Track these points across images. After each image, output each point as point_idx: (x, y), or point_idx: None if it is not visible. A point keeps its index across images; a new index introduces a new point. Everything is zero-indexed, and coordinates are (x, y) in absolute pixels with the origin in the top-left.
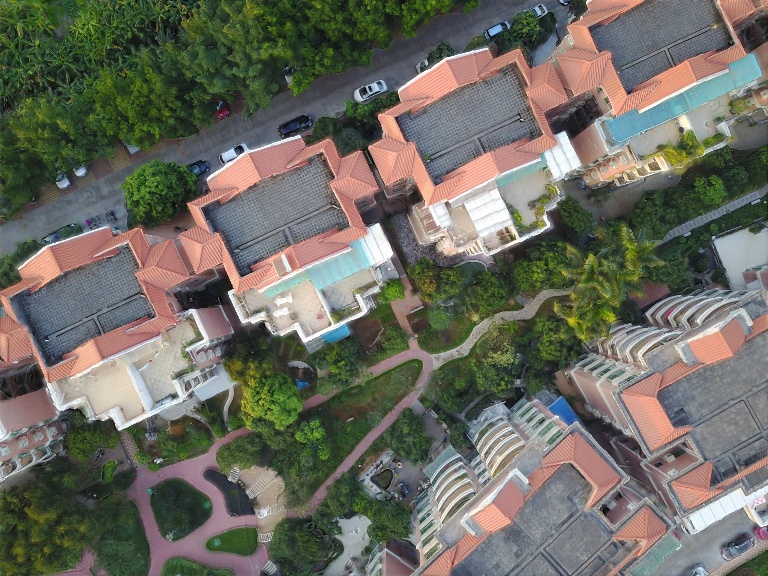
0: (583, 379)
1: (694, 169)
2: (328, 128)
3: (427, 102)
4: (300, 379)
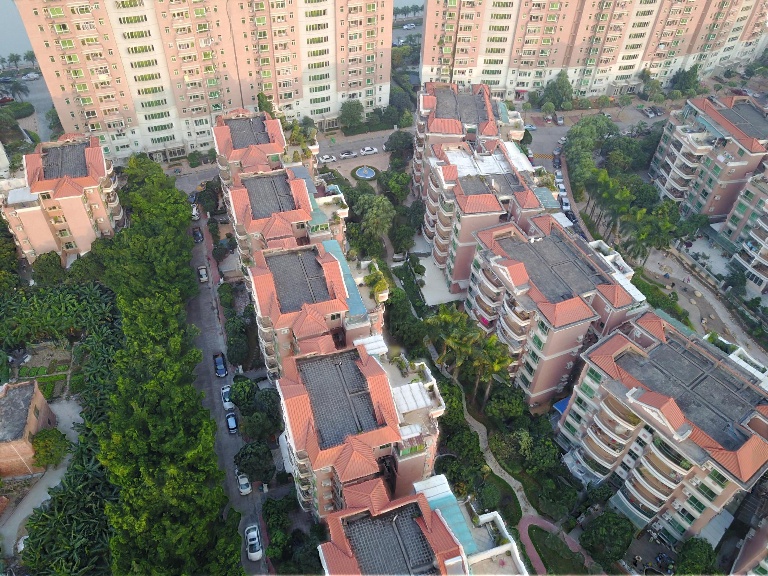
0: (539, 380)
1: None
2: (290, 572)
3: (313, 424)
4: None
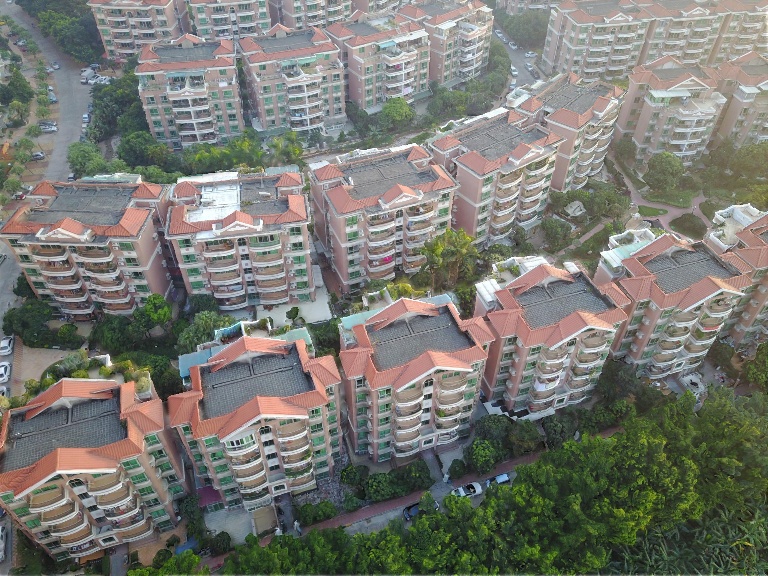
0: None
1: None
2: None
3: None
4: None
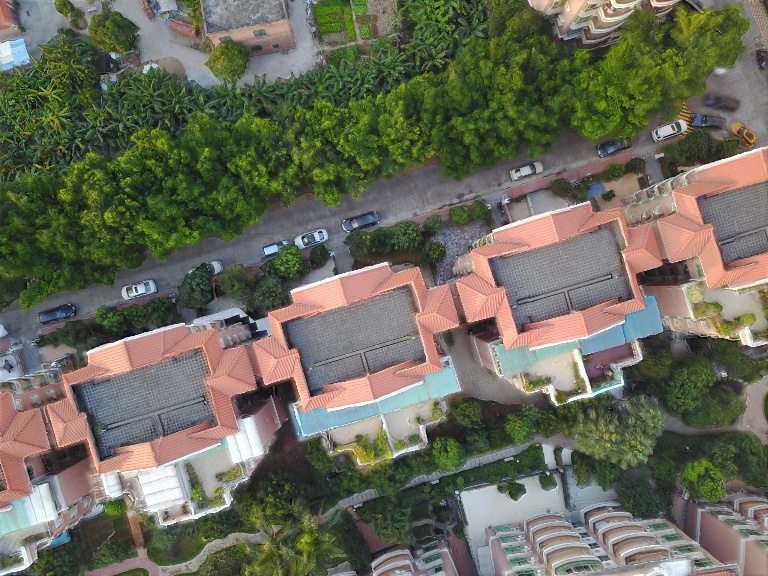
0: None
1: (452, 417)
2: (69, 336)
3: (107, 374)
4: (20, 572)
